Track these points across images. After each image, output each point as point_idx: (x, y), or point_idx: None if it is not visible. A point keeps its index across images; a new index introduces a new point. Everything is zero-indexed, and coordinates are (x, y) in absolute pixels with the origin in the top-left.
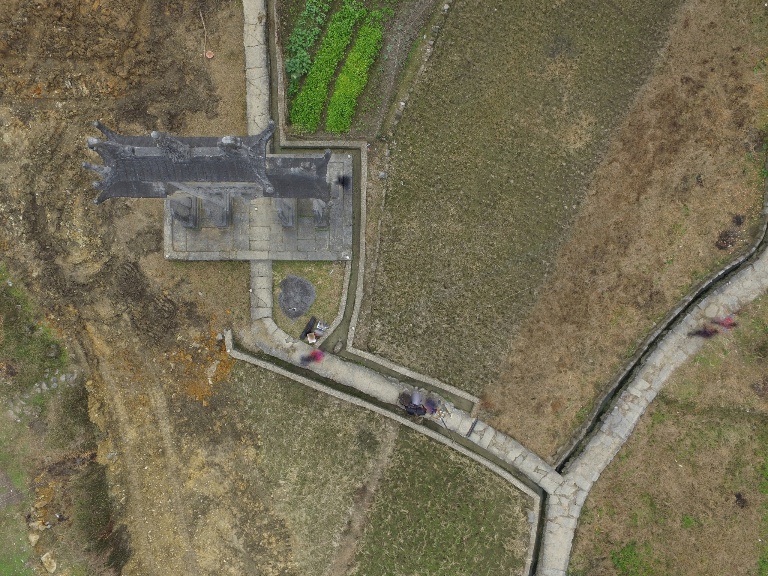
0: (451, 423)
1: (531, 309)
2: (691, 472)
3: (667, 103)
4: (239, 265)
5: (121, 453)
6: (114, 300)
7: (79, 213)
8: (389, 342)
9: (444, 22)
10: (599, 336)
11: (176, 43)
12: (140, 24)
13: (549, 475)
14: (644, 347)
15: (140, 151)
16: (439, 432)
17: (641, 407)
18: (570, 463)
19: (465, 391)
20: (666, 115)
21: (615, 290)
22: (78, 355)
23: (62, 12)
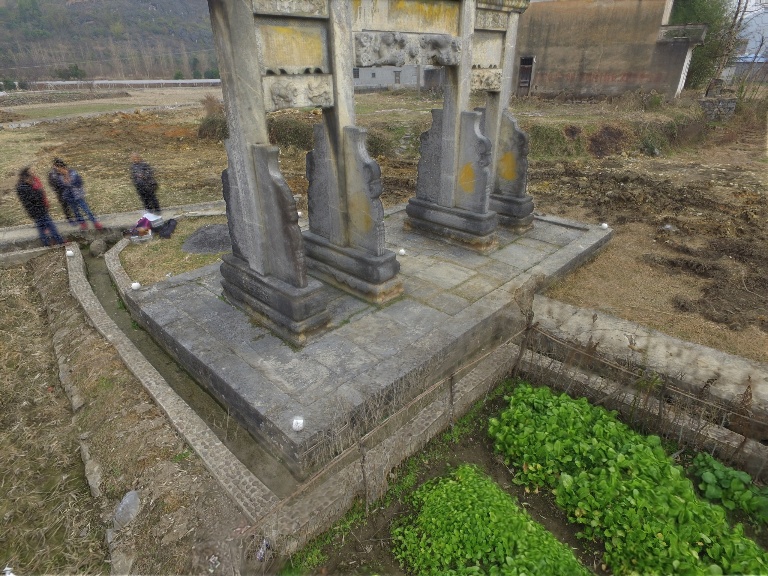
0: None
1: None
2: None
3: None
4: None
5: None
6: None
7: None
8: None
9: None
10: None
11: None
12: None
13: None
14: None
15: None
16: None
17: None
18: None
19: None
20: None
21: None
22: (414, 160)
23: None
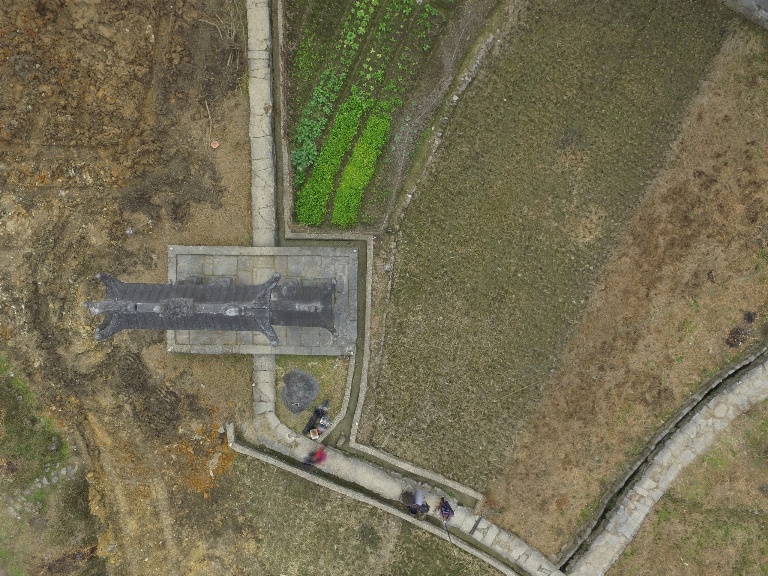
0: (454, 520)
1: (537, 405)
2: (697, 571)
3: (679, 197)
4: (242, 357)
5: (121, 544)
6: (116, 390)
7: (82, 302)
8: (393, 436)
9: (453, 112)
10: (606, 433)
11: (181, 132)
12: (145, 112)
13: (553, 574)
14: (651, 447)
15: (142, 307)
16: (442, 527)
17: (647, 507)
18: (574, 561)
19: (469, 487)
20: (677, 209)
21: (623, 387)
22: (79, 446)
23: (66, 100)
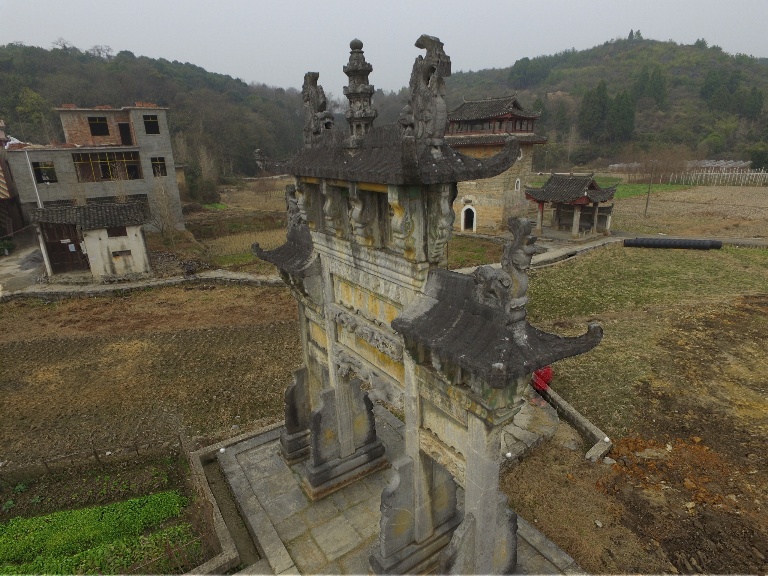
0: None
1: None
2: None
3: None
4: None
5: None
6: None
7: None
8: None
9: None
10: None
11: None
12: None
13: None
14: None
15: None
16: None
17: None
18: None
19: None
20: None
21: None
22: None
23: None
